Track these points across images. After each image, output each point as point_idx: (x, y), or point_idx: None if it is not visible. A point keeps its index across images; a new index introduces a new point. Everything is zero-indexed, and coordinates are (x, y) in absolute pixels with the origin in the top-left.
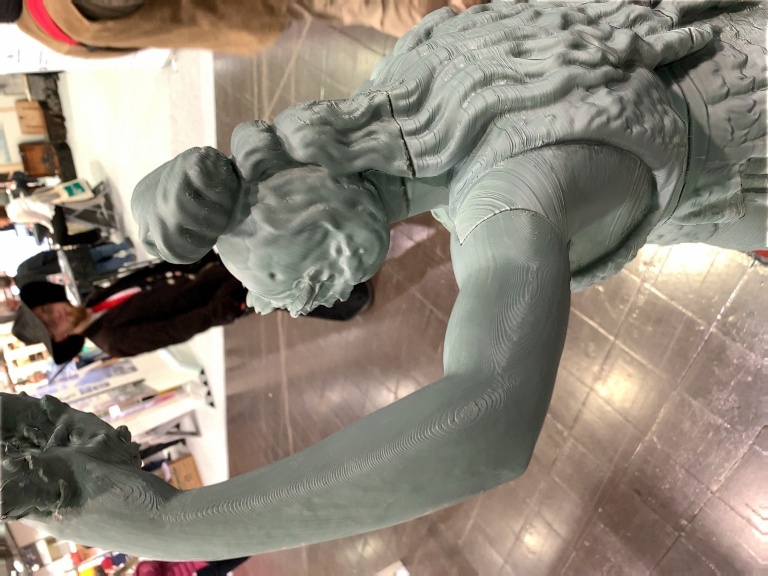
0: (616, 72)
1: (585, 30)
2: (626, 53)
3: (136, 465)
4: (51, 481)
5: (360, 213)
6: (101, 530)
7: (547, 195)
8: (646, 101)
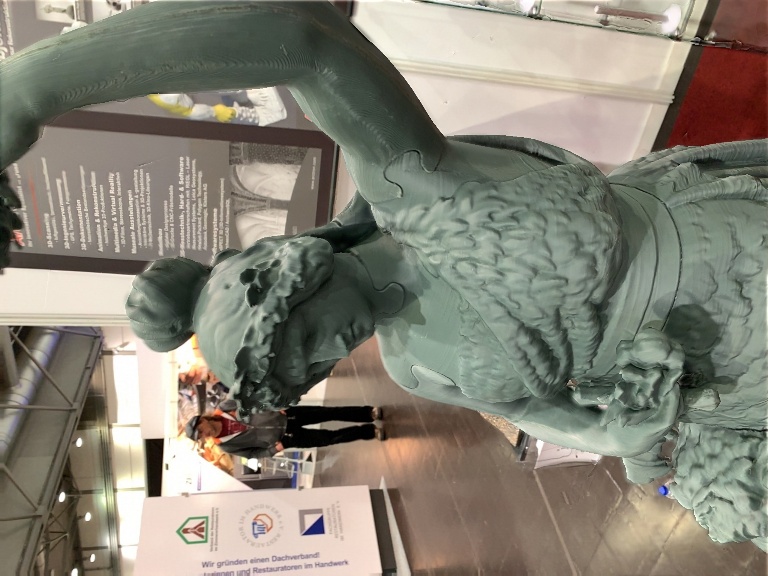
0: None
1: None
2: None
3: (11, 195)
4: None
5: None
6: None
7: None
8: None
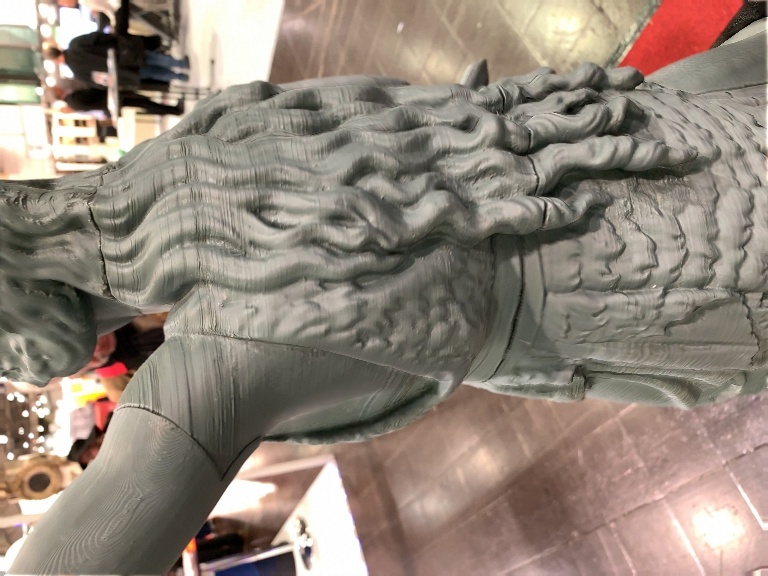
0: (378, 264)
1: (379, 188)
2: (420, 232)
3: None
4: None
5: (43, 322)
6: None
7: (209, 404)
8: (410, 305)
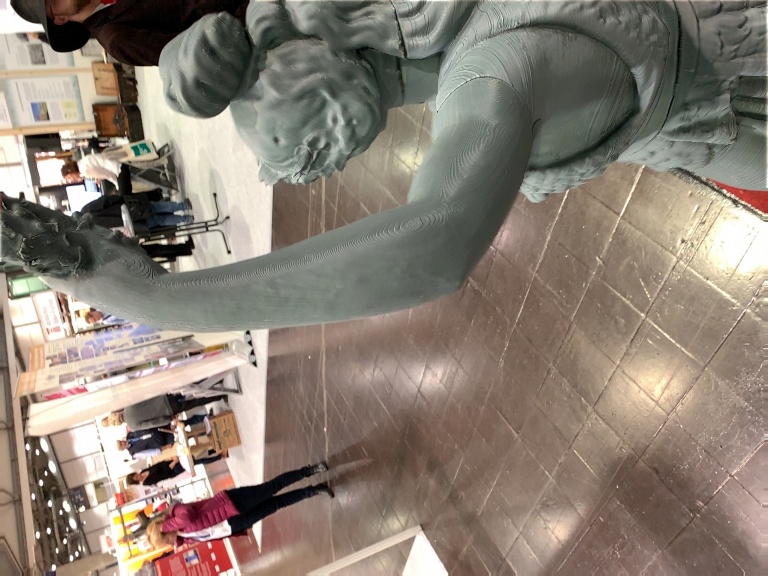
0: None
1: None
2: None
3: None
4: (72, 246)
5: (355, 86)
6: (108, 289)
7: (516, 68)
8: None
